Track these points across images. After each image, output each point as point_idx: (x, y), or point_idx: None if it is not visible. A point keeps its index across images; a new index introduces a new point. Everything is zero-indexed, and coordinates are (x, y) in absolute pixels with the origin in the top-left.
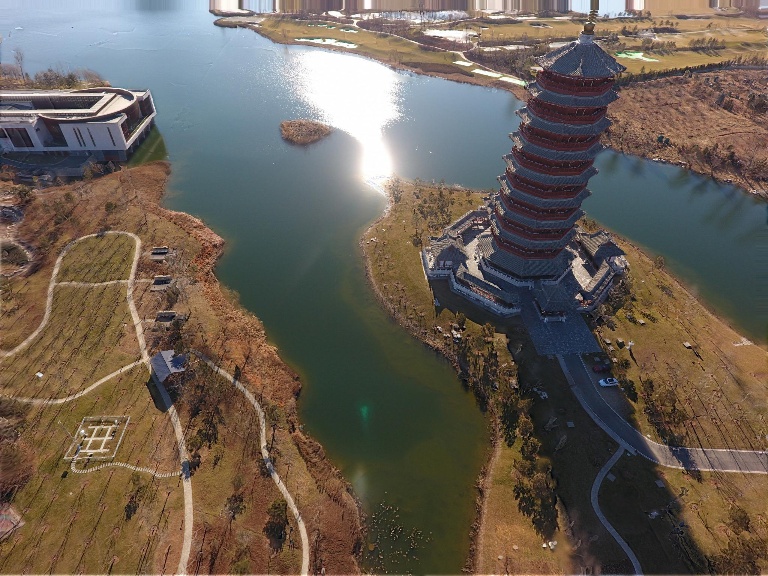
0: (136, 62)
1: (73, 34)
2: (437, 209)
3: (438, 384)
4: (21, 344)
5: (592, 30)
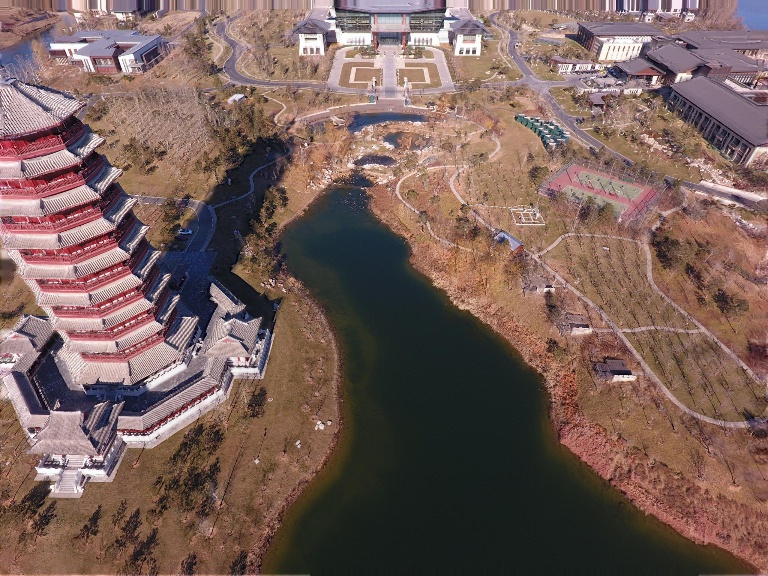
0: None
1: None
2: None
3: (304, 261)
4: None
5: None
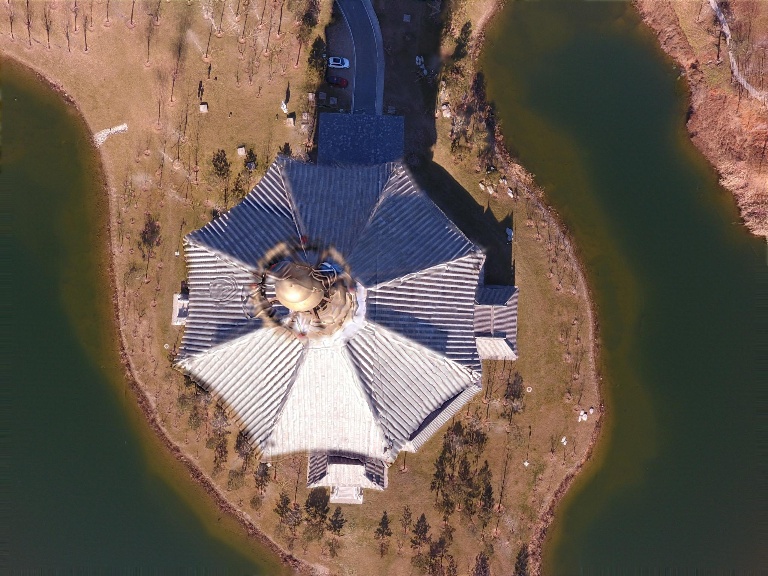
0: None
1: None
2: None
3: (524, 118)
4: None
5: None
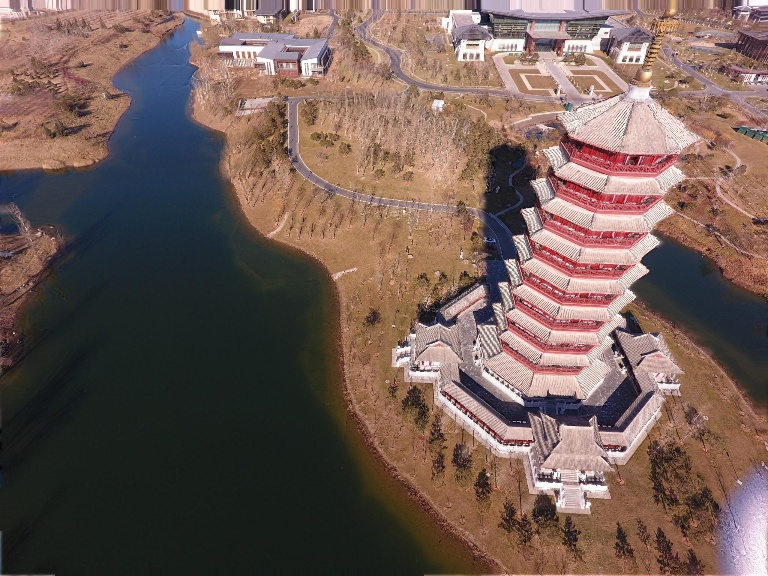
0: None
1: None
2: (688, 514)
3: None
4: None
5: (637, 78)
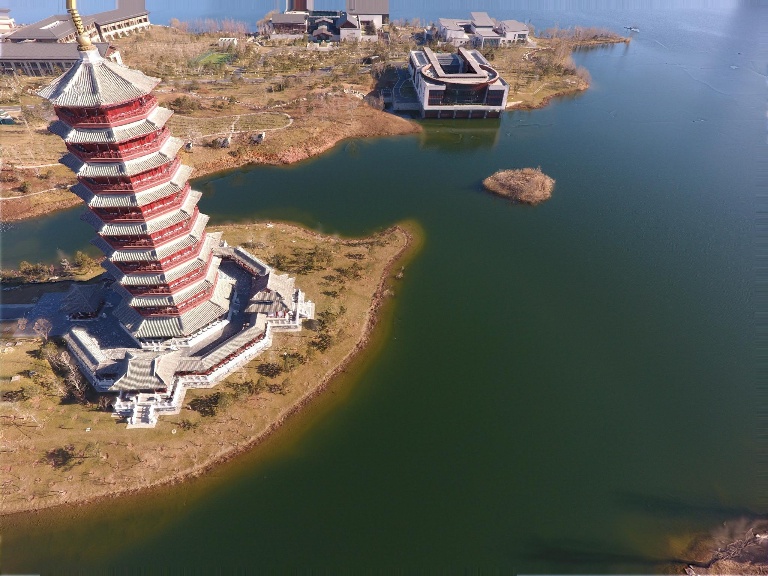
0: (662, 89)
1: (708, 56)
2: None
3: None
4: (189, 117)
5: (82, 45)
